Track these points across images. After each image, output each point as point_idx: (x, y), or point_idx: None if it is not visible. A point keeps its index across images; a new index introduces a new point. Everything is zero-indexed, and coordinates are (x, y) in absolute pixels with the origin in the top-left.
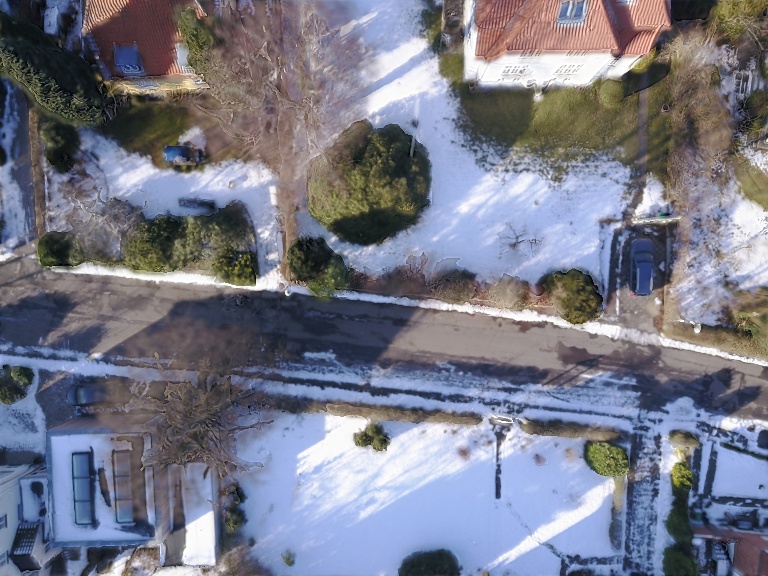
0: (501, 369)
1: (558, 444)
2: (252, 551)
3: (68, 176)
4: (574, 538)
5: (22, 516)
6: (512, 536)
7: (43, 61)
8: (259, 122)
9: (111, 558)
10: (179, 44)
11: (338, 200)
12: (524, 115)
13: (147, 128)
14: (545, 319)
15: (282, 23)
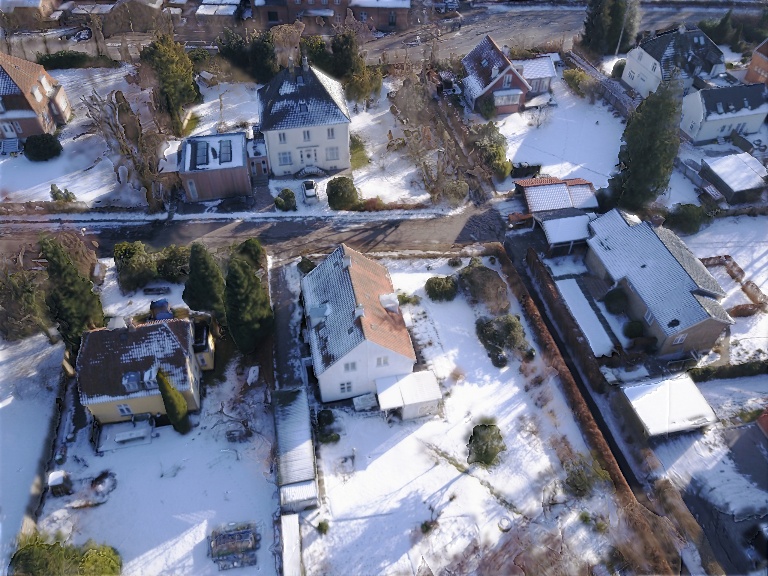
0: None
1: None
2: None
3: None
4: None
5: None
6: None
7: None
8: None
9: None
10: None
11: None
12: None
13: None
14: None
15: None
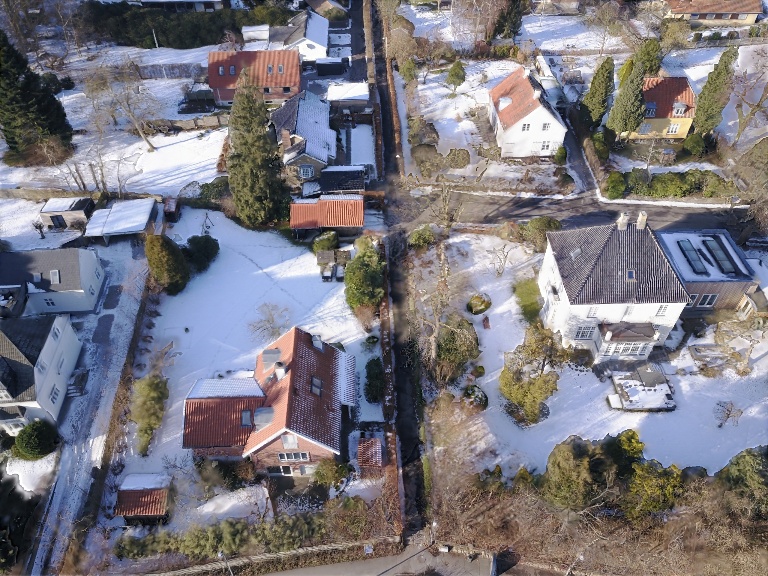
0: None
1: None
2: None
3: (603, 168)
4: None
5: None
6: None
7: None
8: None
9: None
10: (676, 103)
11: None
12: None
13: (642, 152)
14: None
15: None
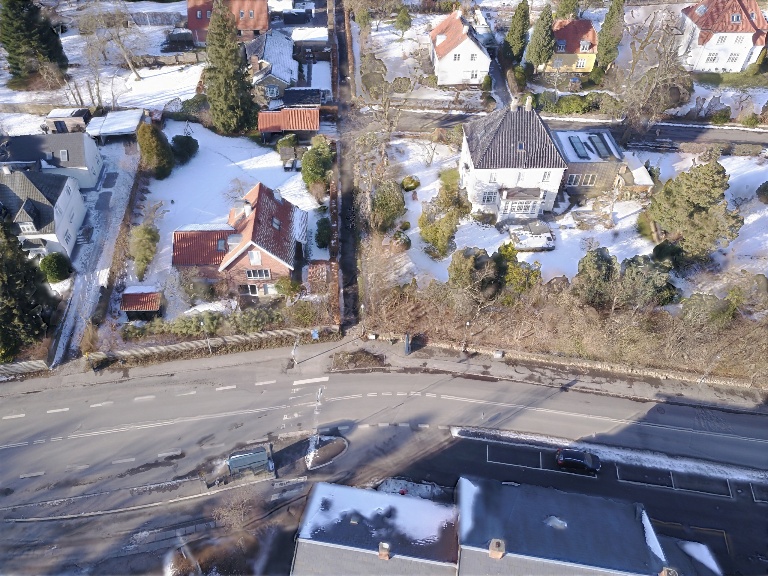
0: (758, 144)
1: None
2: None
3: (522, 93)
4: None
5: None
6: None
7: None
8: None
9: None
10: (582, 41)
11: None
12: None
13: None
14: (767, 131)
15: None
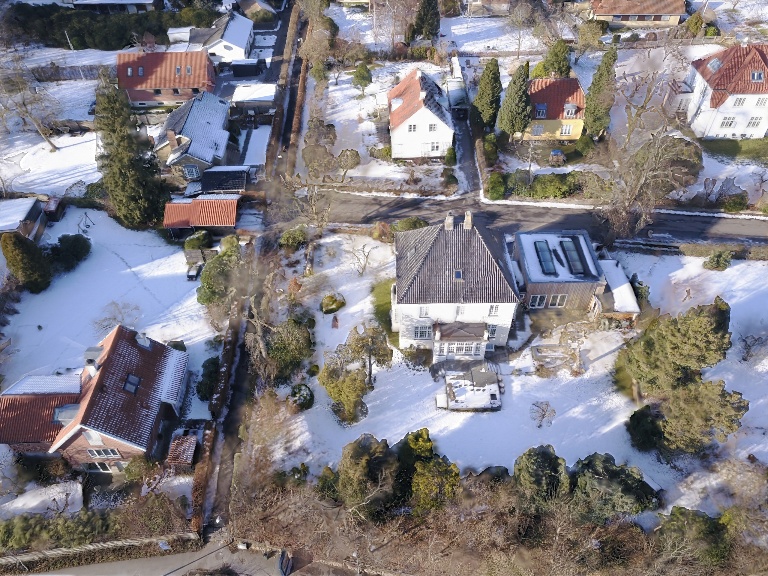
0: None
1: None
2: None
3: (492, 169)
4: None
5: None
6: None
7: None
8: None
9: None
10: (566, 104)
11: None
12: None
13: None
14: None
15: None
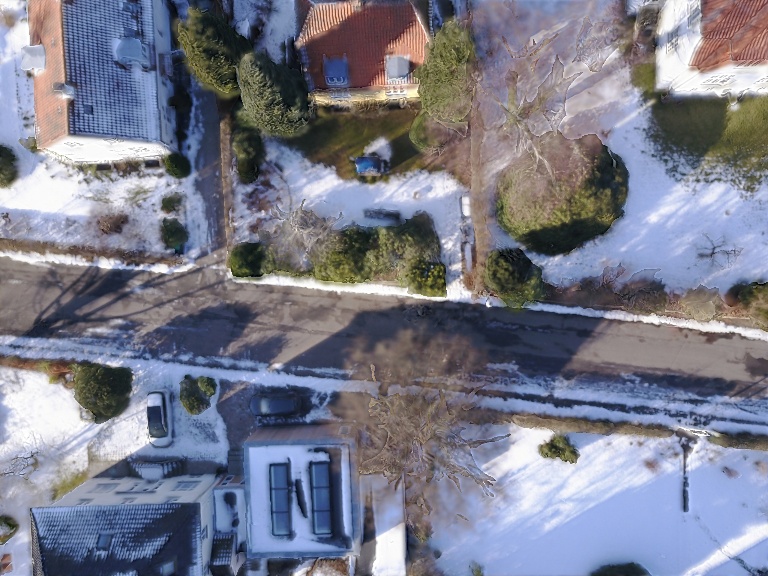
0: (687, 381)
1: (747, 457)
2: (436, 563)
3: (252, 187)
4: (765, 553)
5: (215, 526)
6: (701, 550)
7: (275, 75)
8: (447, 133)
9: (291, 569)
10: (388, 56)
11: (541, 211)
12: (716, 124)
13: (332, 139)
14: (733, 330)
15: (470, 34)
